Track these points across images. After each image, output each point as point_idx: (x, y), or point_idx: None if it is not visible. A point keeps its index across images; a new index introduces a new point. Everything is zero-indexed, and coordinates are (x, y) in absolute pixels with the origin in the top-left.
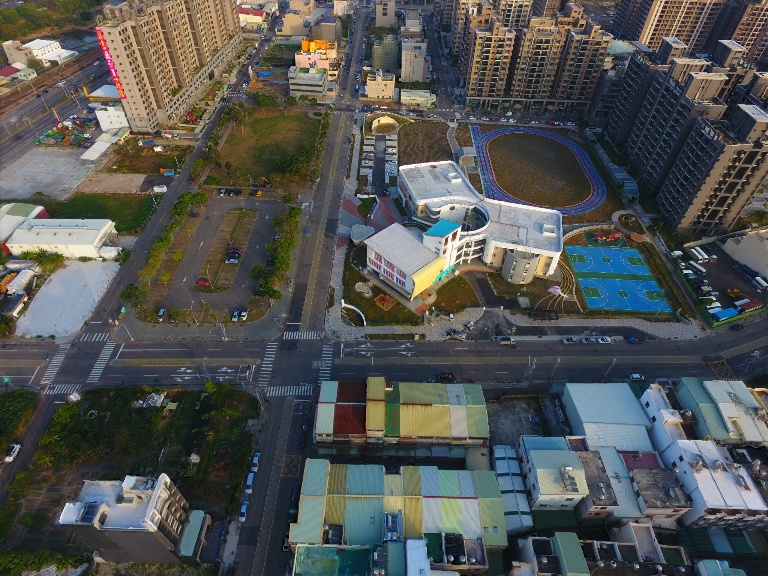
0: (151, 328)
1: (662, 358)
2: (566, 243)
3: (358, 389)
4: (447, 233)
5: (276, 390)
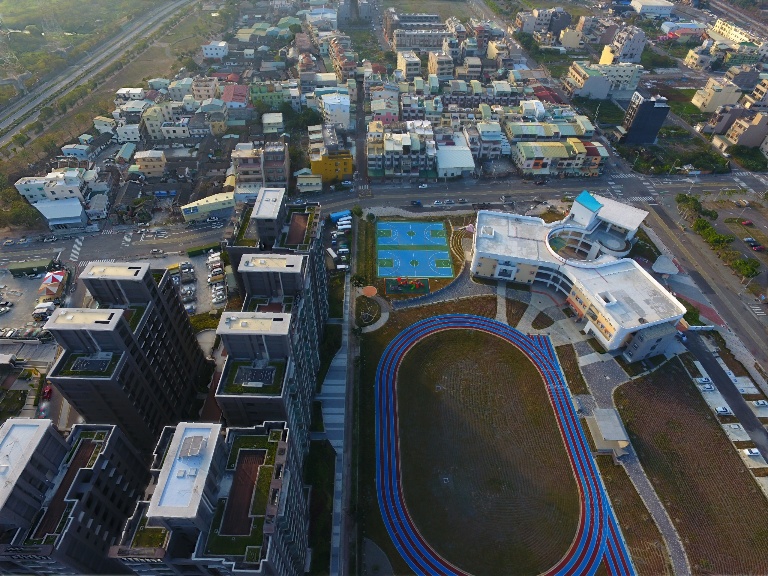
0: (741, 199)
1: (401, 197)
2: (451, 280)
3: (589, 152)
4: (584, 192)
5: (632, 176)
